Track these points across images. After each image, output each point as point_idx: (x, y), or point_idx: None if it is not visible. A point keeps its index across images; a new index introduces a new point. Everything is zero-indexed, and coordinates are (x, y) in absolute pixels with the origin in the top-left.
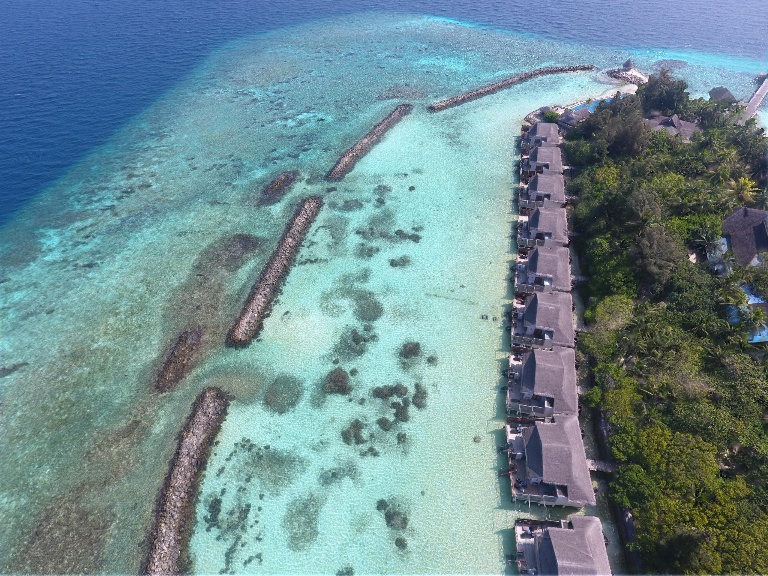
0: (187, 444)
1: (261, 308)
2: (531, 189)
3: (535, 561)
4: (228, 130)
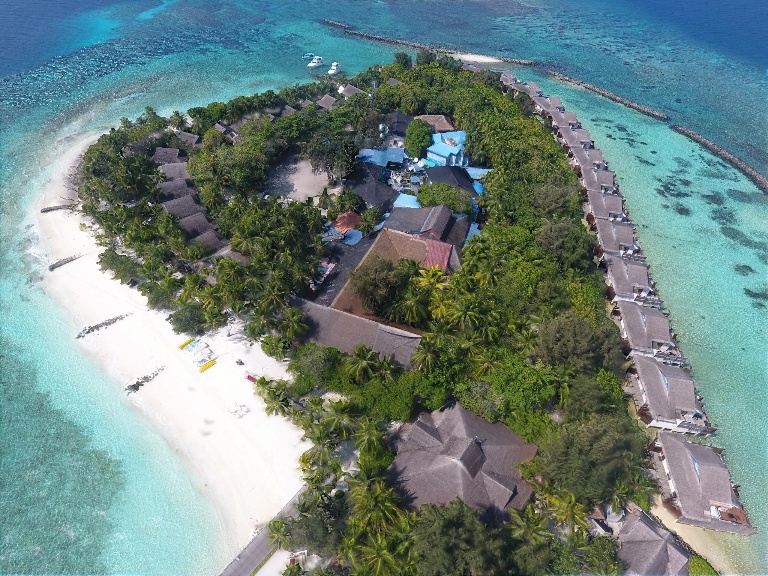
0: (763, 177)
1: None
2: None
3: None
4: None
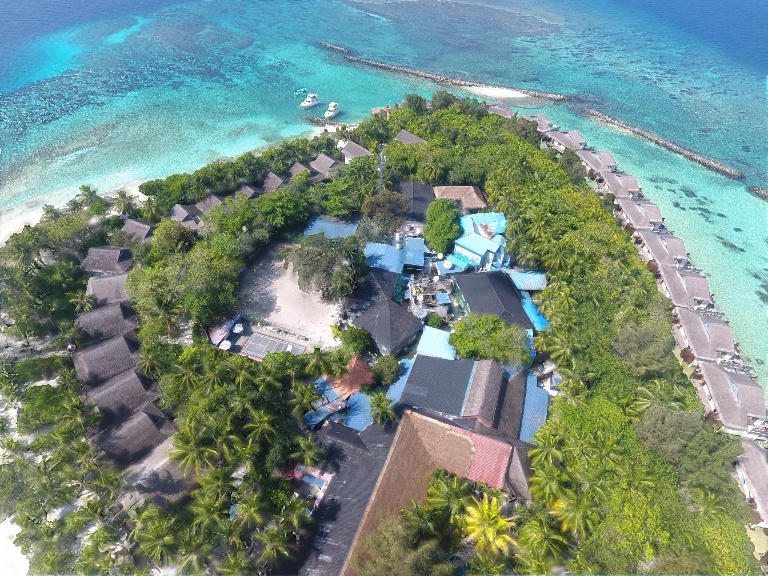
0: None
1: None
2: None
3: None
4: None
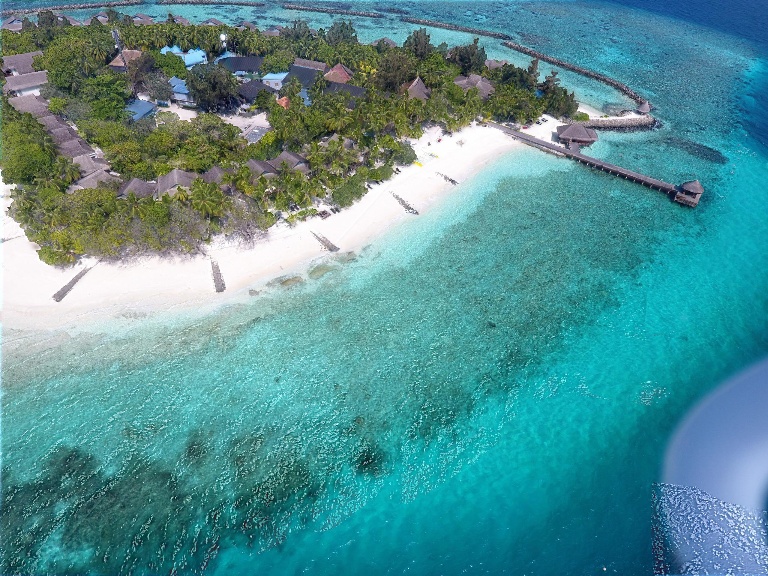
0: (242, 1)
1: (301, 8)
2: None
3: None
4: (454, 3)
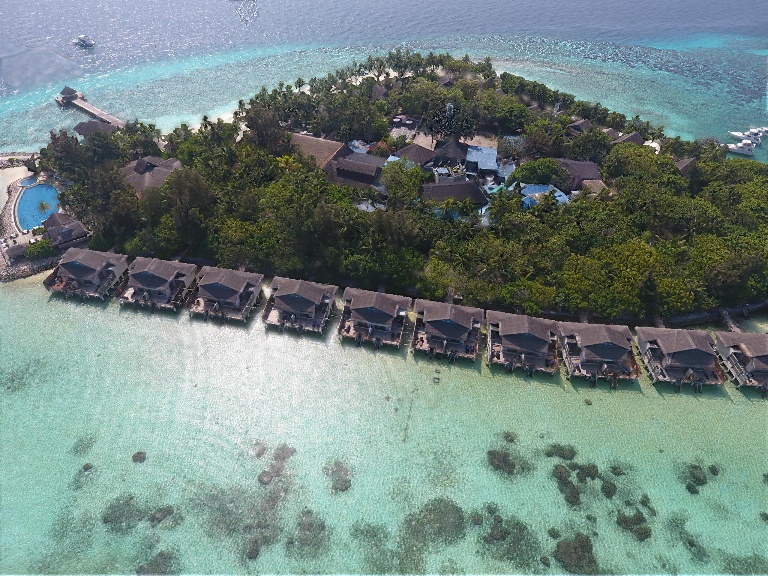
0: None
1: None
2: (229, 298)
3: (677, 372)
4: None
